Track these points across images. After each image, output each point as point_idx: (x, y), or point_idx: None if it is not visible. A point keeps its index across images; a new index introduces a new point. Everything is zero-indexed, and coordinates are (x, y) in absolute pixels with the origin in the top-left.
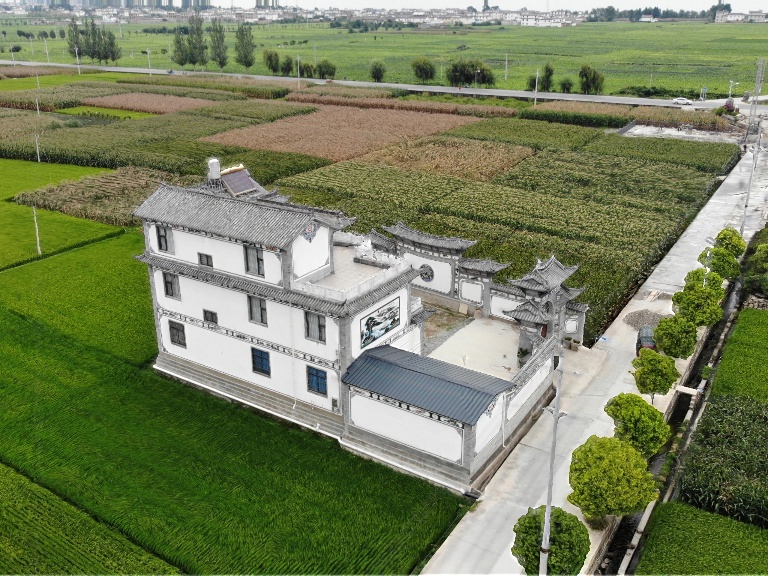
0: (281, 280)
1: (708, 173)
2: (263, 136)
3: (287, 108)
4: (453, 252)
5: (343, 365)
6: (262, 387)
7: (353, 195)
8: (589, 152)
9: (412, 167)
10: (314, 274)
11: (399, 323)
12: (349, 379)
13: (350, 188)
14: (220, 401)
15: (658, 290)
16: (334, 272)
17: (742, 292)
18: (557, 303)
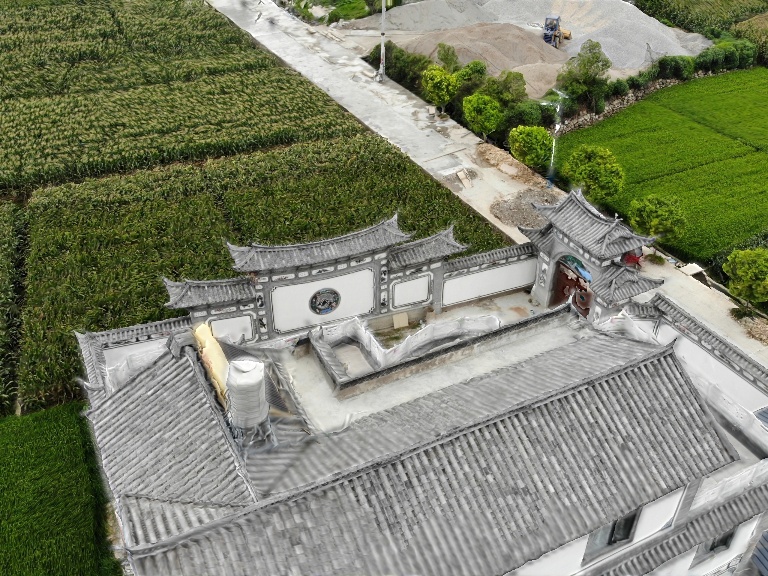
0: (672, 517)
1: (194, 0)
2: None
3: None
4: (378, 250)
5: (750, 552)
6: None
7: None
8: (11, 8)
9: None
10: None
11: None
12: None
13: None
14: None
15: (448, 169)
16: None
17: (499, 134)
18: None
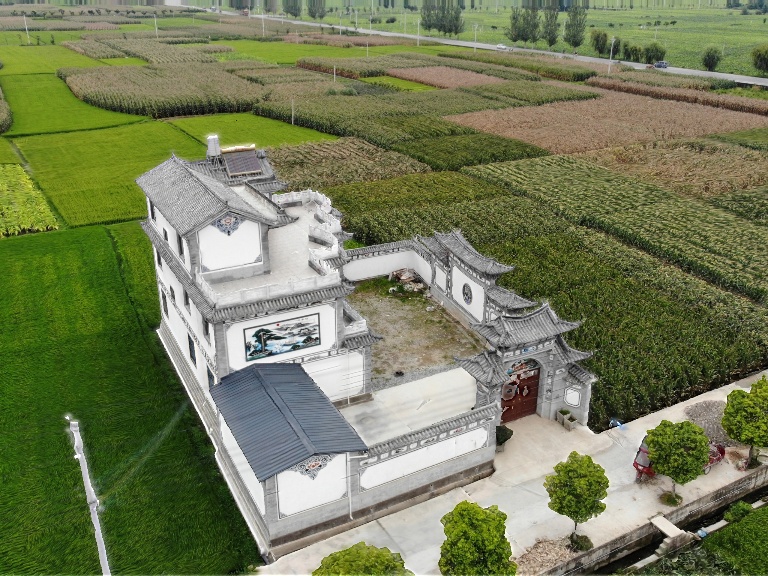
0: None
1: None
2: (508, 119)
3: (565, 92)
4: (485, 275)
5: (218, 374)
6: (194, 375)
7: (526, 193)
8: None
9: (627, 171)
10: (236, 270)
11: (320, 343)
12: (215, 390)
13: (528, 185)
14: (172, 379)
15: None
16: (270, 272)
17: None
18: (550, 364)
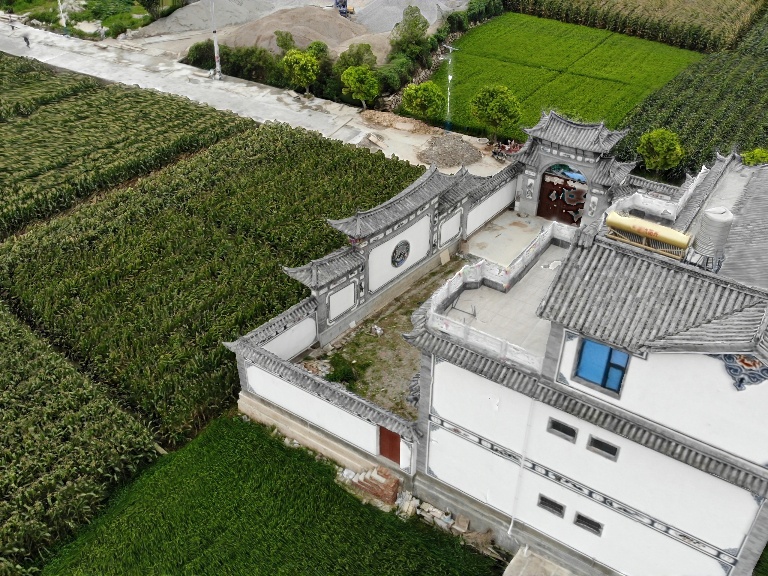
0: None
1: None
2: None
3: None
4: None
5: None
6: None
7: None
8: None
9: None
10: None
11: None
12: None
13: None
14: None
15: (355, 137)
16: None
17: (370, 101)
18: None
